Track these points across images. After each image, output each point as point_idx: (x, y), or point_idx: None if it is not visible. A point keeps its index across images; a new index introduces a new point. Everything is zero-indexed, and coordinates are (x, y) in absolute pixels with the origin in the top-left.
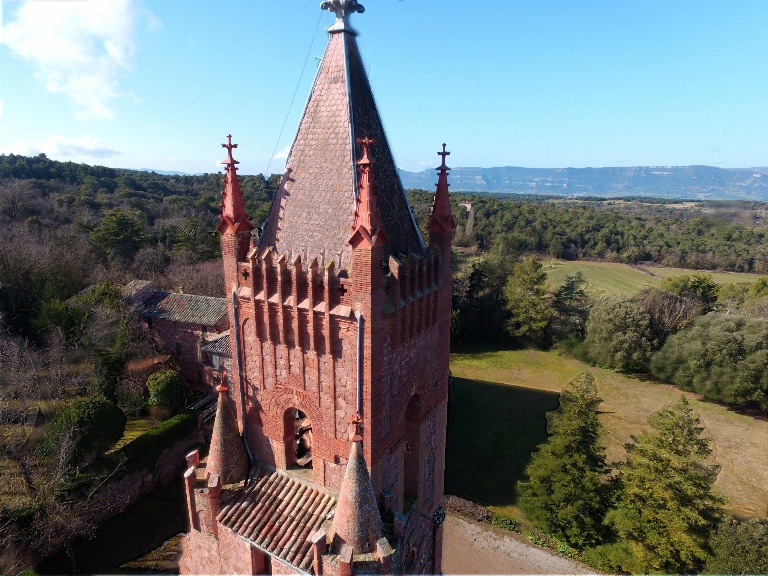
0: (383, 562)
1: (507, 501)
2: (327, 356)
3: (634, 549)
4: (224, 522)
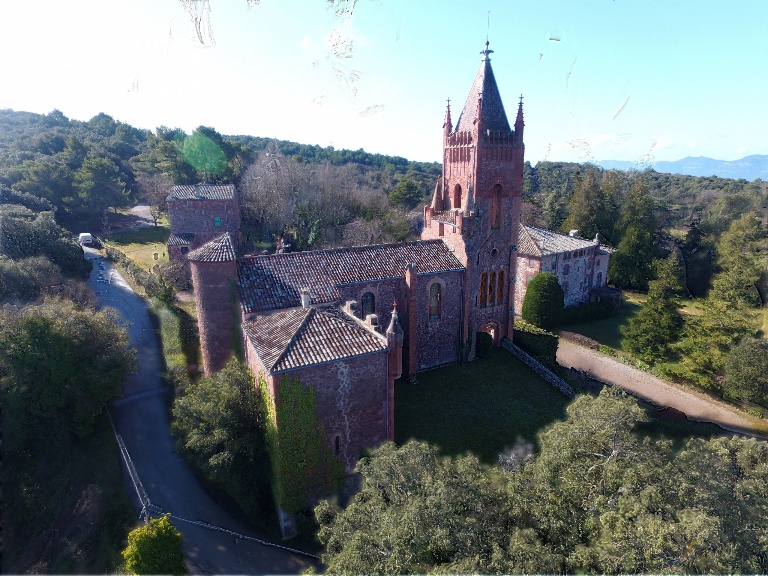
0: (471, 216)
1: (621, 349)
2: (467, 162)
3: (684, 362)
4: (433, 218)
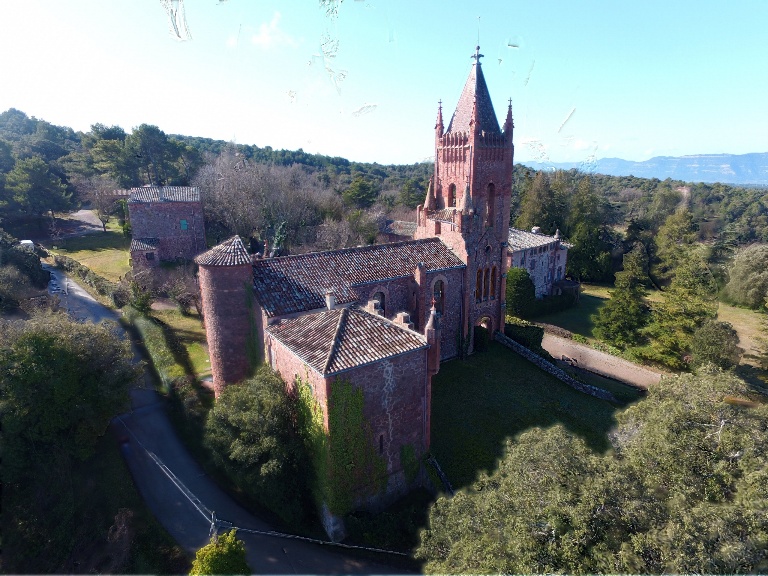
0: (470, 214)
1: (590, 337)
2: (462, 162)
3: None
4: (428, 217)
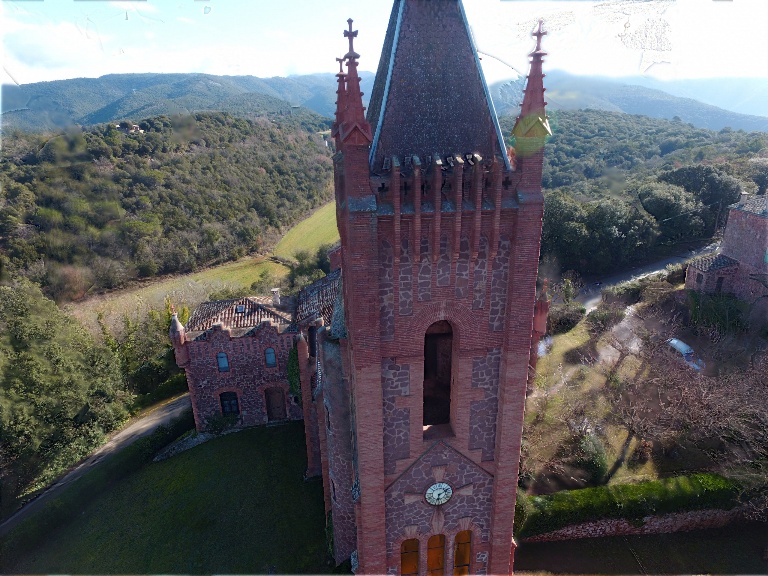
0: None
1: None
2: None
3: None
4: None
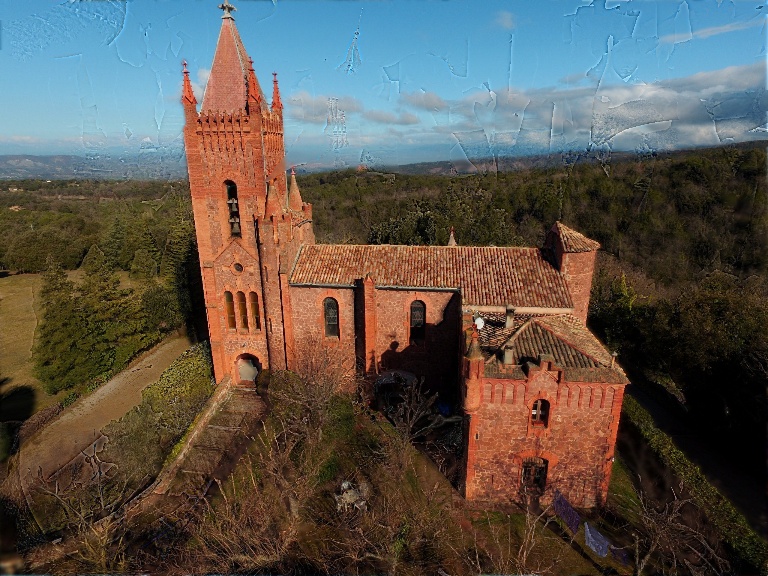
0: None
1: (30, 409)
2: None
3: (129, 340)
4: None
